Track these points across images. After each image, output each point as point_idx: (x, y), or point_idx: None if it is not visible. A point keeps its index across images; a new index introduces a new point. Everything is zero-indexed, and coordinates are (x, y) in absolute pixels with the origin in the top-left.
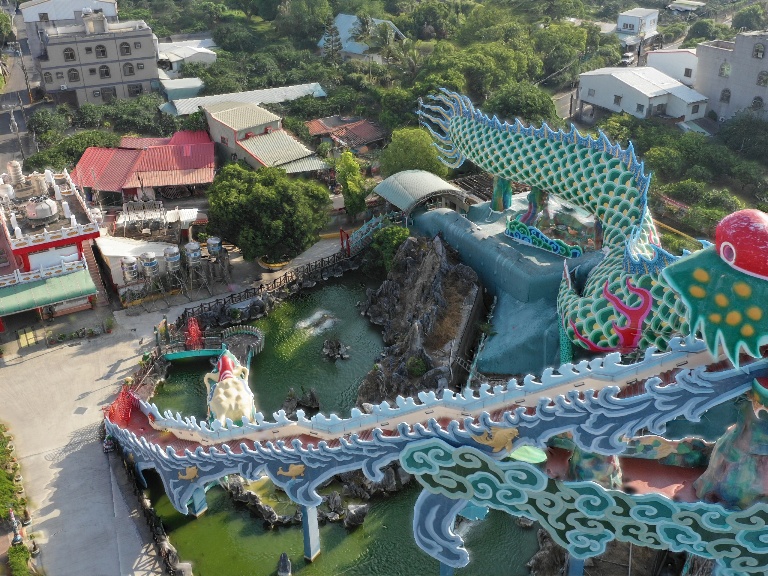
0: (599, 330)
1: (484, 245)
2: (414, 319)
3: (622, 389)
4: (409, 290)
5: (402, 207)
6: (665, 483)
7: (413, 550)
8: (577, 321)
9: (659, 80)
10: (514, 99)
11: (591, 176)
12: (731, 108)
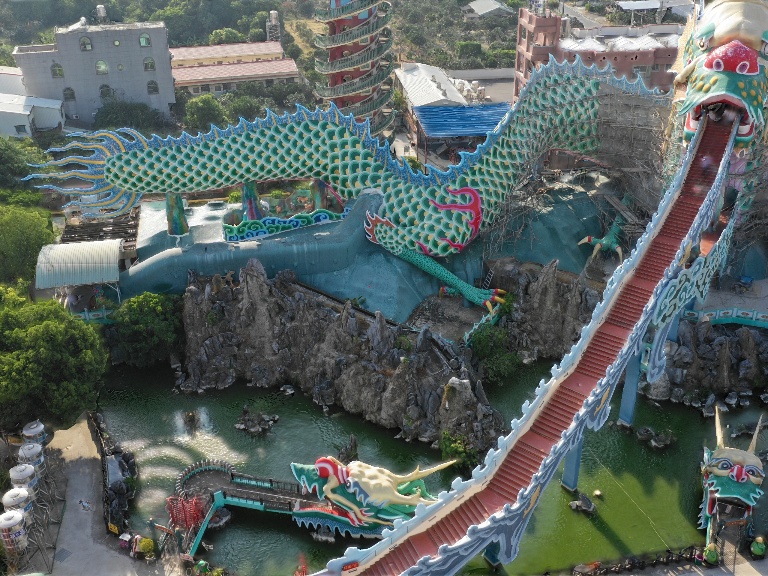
0: (464, 231)
1: (268, 249)
2: (300, 338)
3: (685, 189)
4: (248, 328)
5: (112, 279)
6: None
7: None
8: (448, 235)
9: (5, 99)
10: None
11: (313, 144)
12: (80, 104)
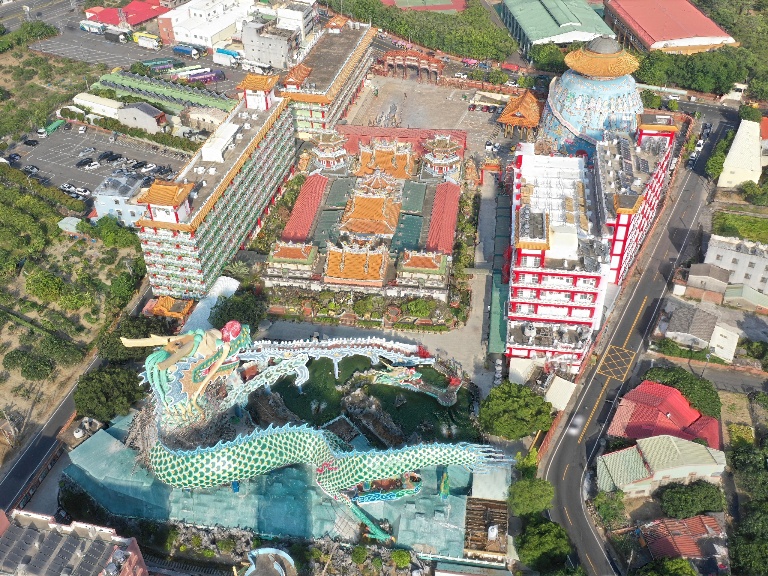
0: None
1: None
2: None
3: None
4: None
5: None
6: (250, 377)
7: None
8: None
9: None
10: (559, 572)
11: None
12: None
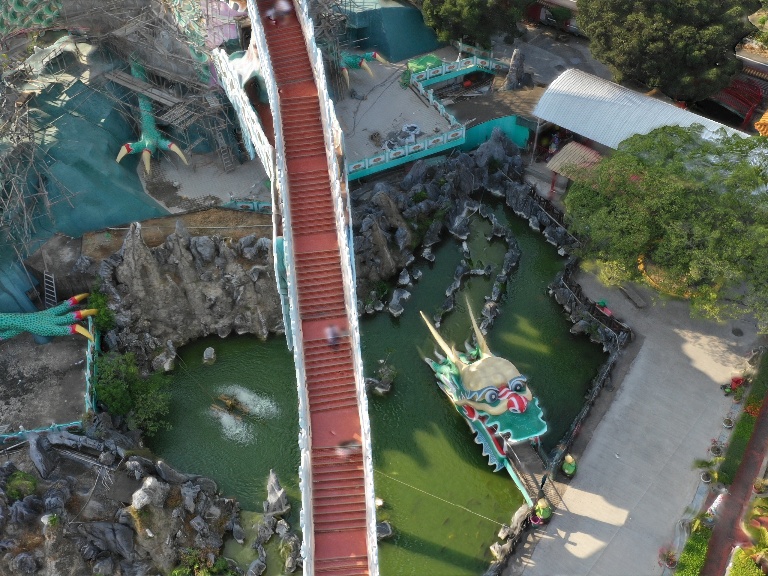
0: None
1: None
2: None
3: (278, 78)
4: None
5: None
6: None
7: (293, 430)
8: None
9: None
10: None
11: None
12: None
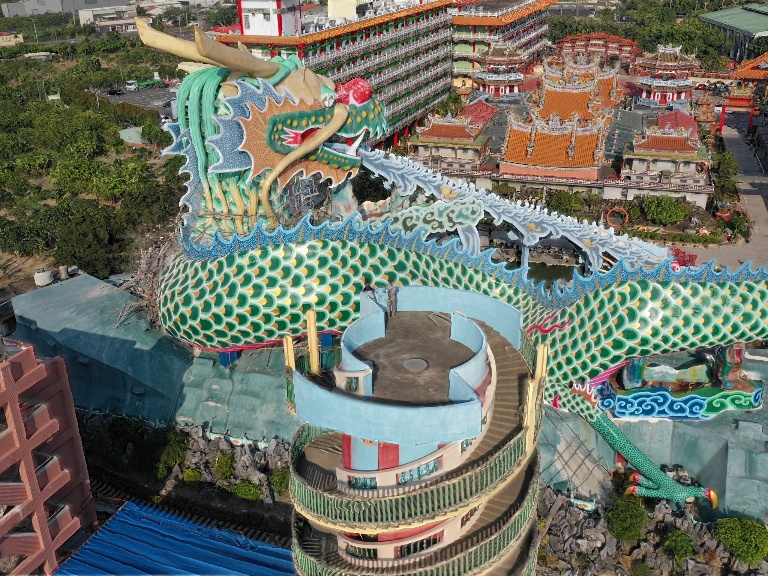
0: None
1: None
2: None
3: None
4: None
5: None
6: None
7: None
8: None
9: None
10: None
11: None
12: None
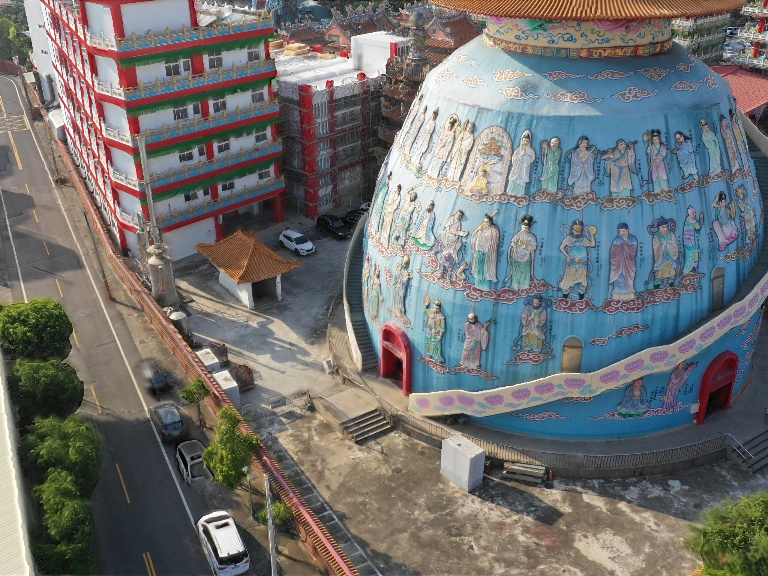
0: None
1: None
2: None
3: None
4: None
5: None
6: None
7: None
8: None
9: None
10: None
11: None
12: None
